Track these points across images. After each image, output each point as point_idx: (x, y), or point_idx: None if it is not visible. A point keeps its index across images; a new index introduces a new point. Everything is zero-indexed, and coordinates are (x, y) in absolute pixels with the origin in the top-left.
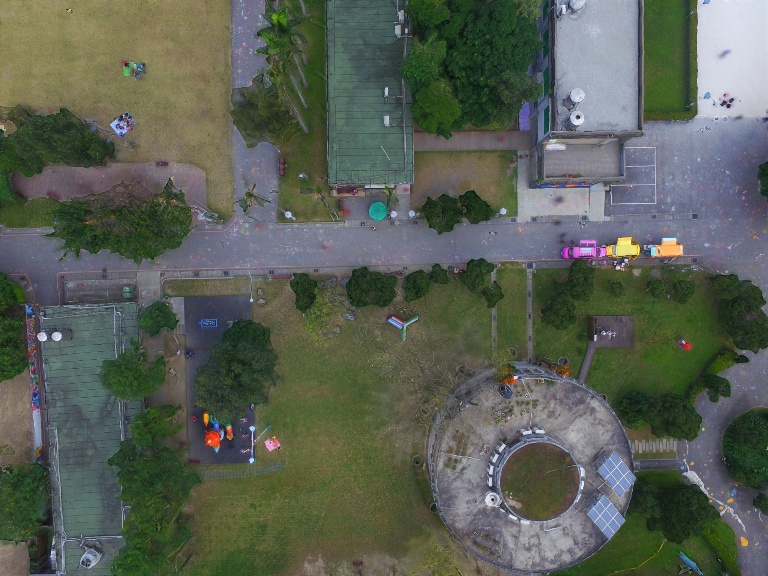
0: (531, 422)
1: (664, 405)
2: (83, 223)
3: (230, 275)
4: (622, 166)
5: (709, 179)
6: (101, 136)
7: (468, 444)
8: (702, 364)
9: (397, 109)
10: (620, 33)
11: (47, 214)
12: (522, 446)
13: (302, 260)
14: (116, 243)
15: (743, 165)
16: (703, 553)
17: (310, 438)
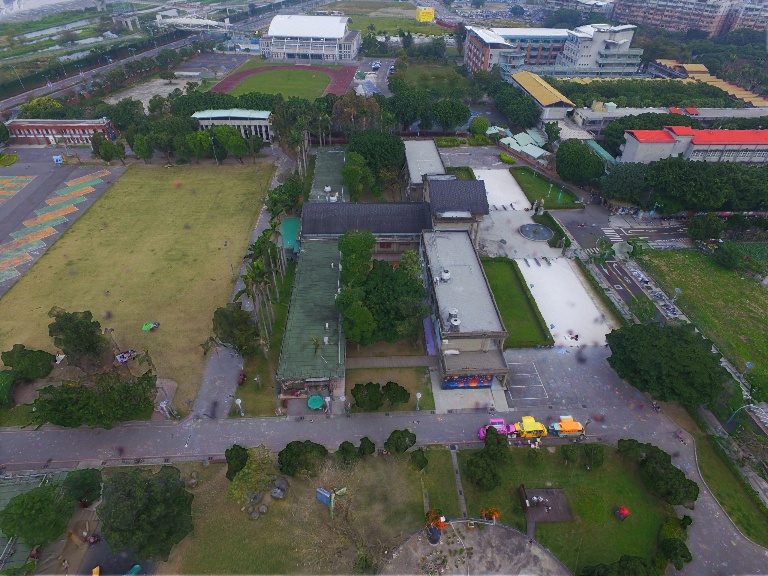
0: (469, 575)
1: (621, 565)
2: (67, 384)
3: (170, 462)
4: (505, 362)
5: (583, 381)
6: (110, 344)
7: None
8: (654, 537)
9: (334, 335)
10: (477, 290)
11: (25, 416)
12: None
13: (242, 447)
14: (84, 406)
15: (605, 372)
16: None
17: None
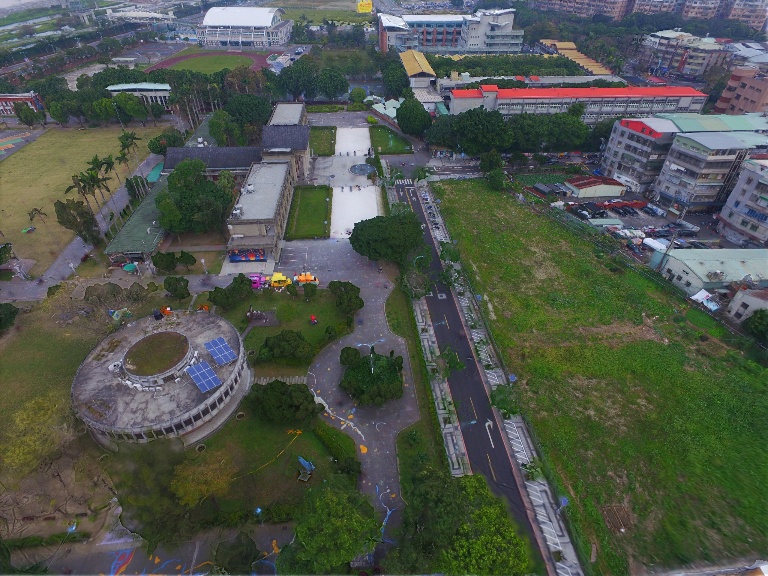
0: None
1: None
2: None
3: (16, 301)
4: None
5: (338, 257)
6: None
7: (118, 346)
8: None
9: (158, 229)
10: (271, 197)
11: None
12: (152, 334)
13: None
14: None
15: None
16: (324, 459)
17: (4, 384)
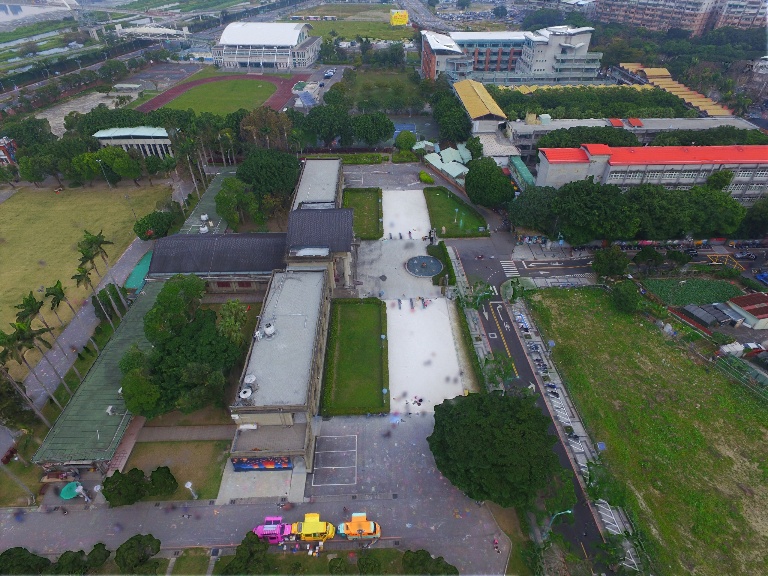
0: None
1: None
2: None
3: None
4: (304, 441)
5: (406, 461)
6: None
7: None
8: None
9: None
10: (301, 347)
11: None
12: None
13: None
14: None
15: None
16: None
17: None
